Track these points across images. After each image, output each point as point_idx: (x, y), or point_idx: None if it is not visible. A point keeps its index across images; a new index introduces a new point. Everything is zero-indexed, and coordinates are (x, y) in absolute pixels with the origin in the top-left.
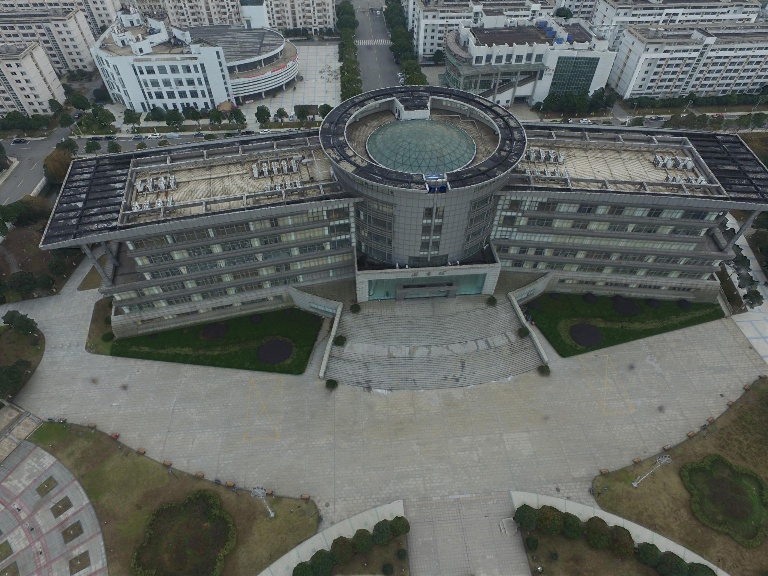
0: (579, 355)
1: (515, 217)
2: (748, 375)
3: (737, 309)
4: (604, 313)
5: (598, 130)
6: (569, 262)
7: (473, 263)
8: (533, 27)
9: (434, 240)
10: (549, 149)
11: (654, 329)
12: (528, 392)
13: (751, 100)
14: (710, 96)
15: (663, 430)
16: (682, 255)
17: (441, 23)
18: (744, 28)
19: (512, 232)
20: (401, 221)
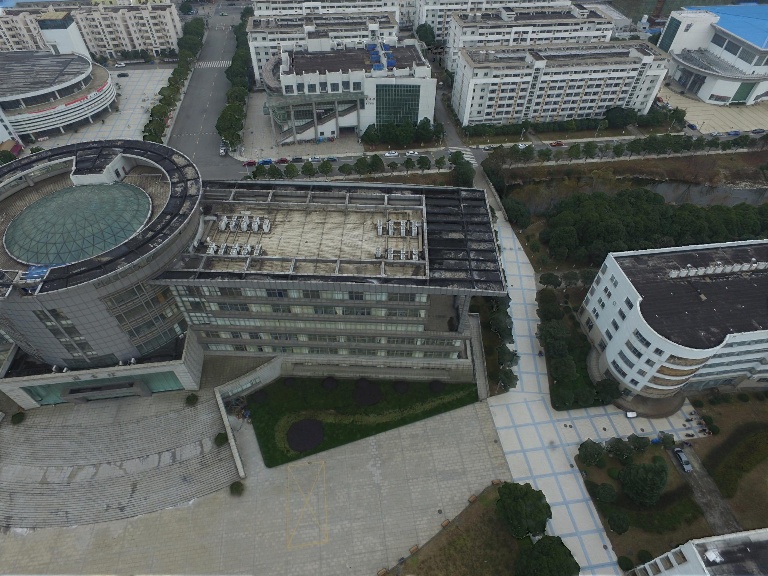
0: (289, 463)
1: (200, 303)
2: (480, 480)
3: (496, 389)
4: (338, 403)
5: (329, 187)
6: (293, 346)
7: (158, 358)
8: (363, 50)
9: (78, 341)
10: (266, 213)
11: (389, 422)
12: (206, 521)
13: (594, 125)
14: (556, 121)
15: (351, 568)
16: (412, 337)
17: (272, 45)
18: (587, 48)
19: (208, 317)
20: (19, 324)
